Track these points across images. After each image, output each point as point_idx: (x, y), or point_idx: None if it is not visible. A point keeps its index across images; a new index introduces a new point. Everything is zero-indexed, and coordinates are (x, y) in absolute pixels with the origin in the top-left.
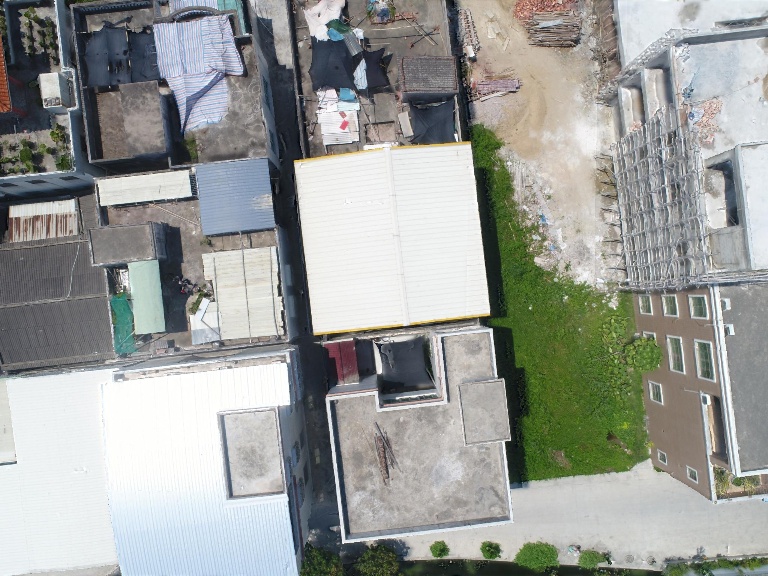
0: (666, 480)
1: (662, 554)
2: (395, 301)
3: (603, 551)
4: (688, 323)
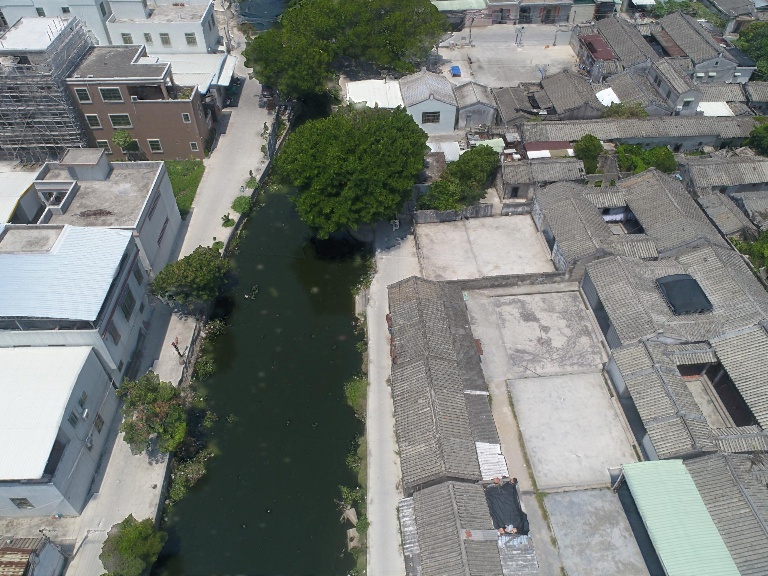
0: (218, 155)
1: (261, 159)
2: (1, 202)
3: (249, 179)
4: (97, 106)
